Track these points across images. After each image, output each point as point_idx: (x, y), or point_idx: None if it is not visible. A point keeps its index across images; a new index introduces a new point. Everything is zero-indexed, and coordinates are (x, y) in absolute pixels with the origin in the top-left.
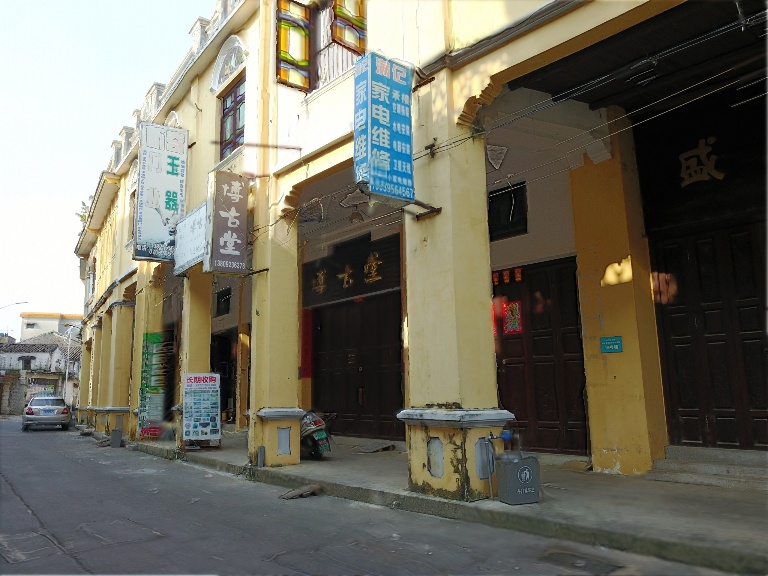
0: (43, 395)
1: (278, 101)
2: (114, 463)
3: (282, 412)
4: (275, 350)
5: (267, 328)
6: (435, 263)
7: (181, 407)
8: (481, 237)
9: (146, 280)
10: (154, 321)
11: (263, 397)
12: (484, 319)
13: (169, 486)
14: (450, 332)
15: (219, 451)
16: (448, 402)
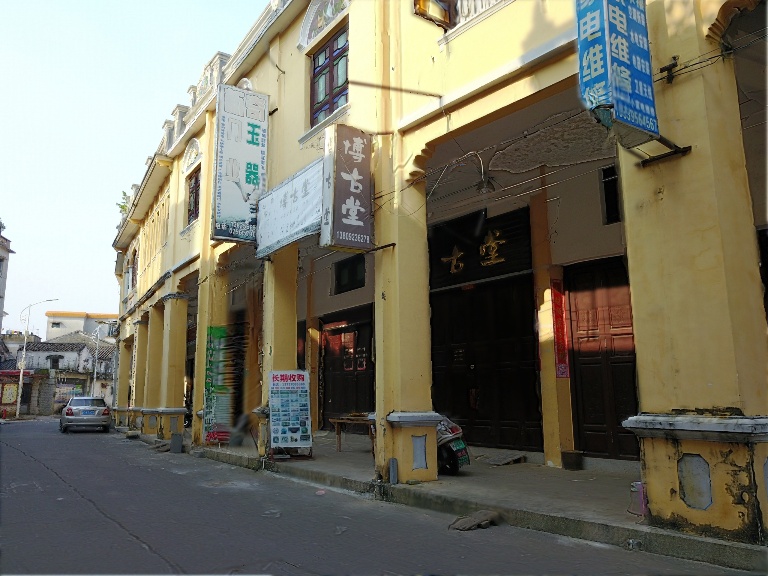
0: (72, 395)
1: (402, 44)
2: (191, 473)
3: (418, 417)
4: (406, 341)
5: (396, 315)
6: (682, 220)
7: (267, 409)
8: (742, 186)
9: (210, 268)
10: (221, 313)
11: (393, 398)
12: (754, 295)
13: (286, 507)
14: (717, 311)
15: (312, 461)
16: (716, 406)
